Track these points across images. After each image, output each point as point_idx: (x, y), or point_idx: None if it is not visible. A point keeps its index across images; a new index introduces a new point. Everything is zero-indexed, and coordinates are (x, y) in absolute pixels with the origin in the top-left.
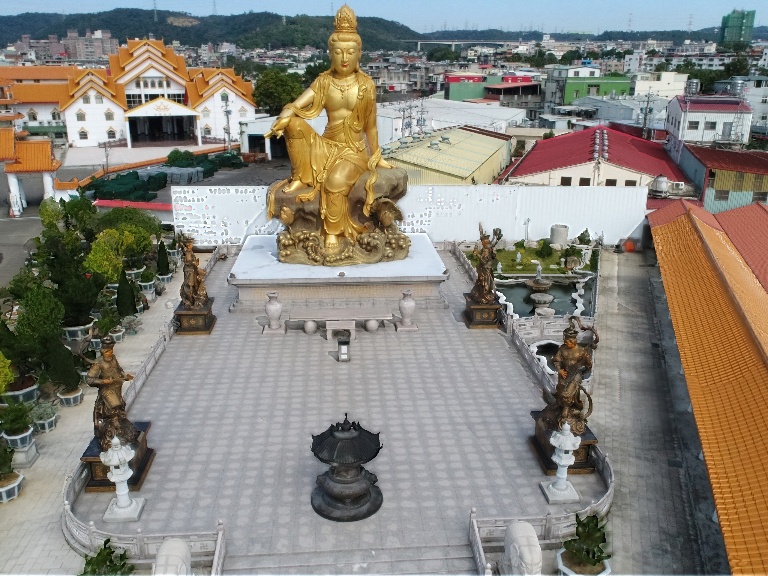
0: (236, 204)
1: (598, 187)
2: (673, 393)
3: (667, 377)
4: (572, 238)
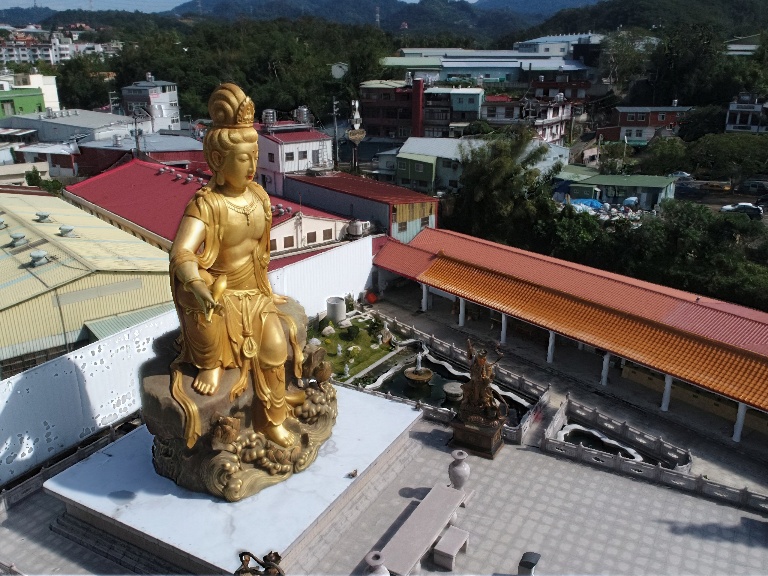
0: None
1: (341, 247)
2: (701, 432)
3: (668, 420)
4: None
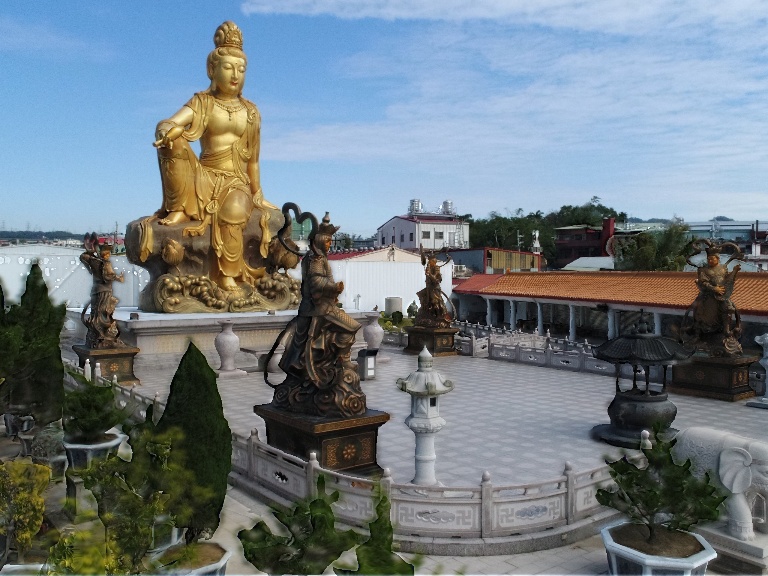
0: (19, 278)
1: (414, 262)
2: None
3: None
4: None
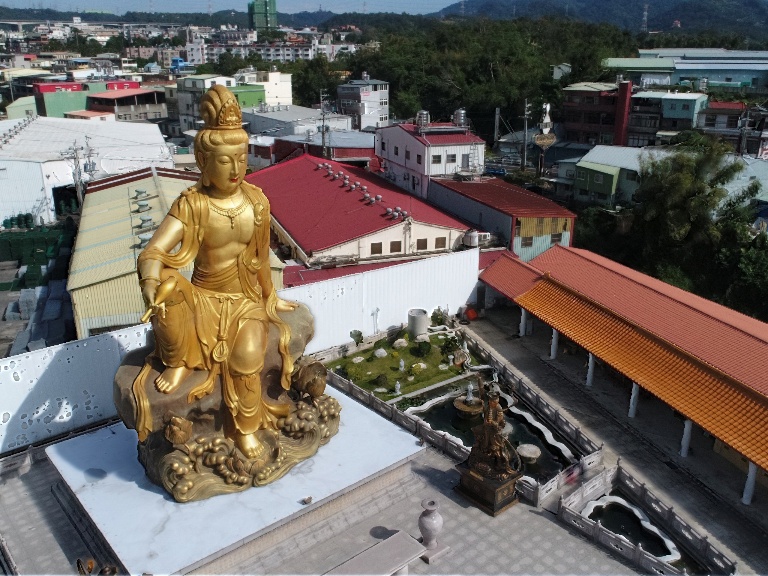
0: None
1: (438, 258)
2: None
3: (743, 515)
4: None
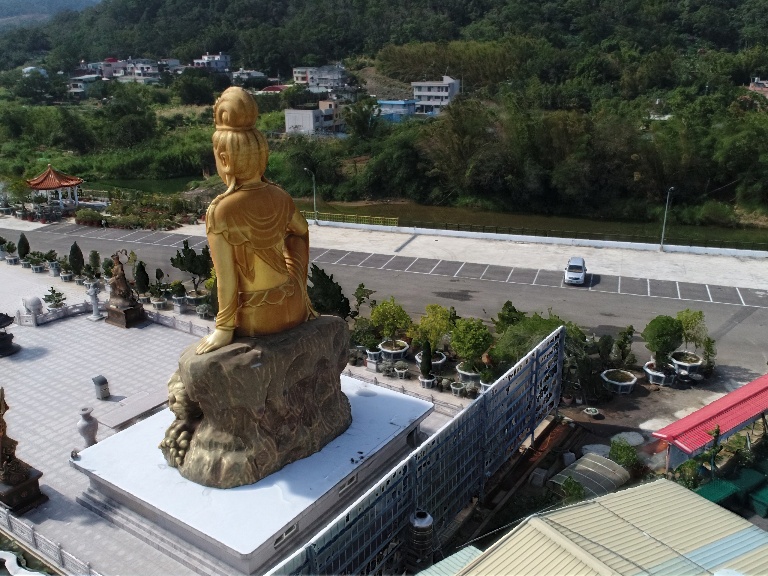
0: None
1: None
2: None
3: None
4: None
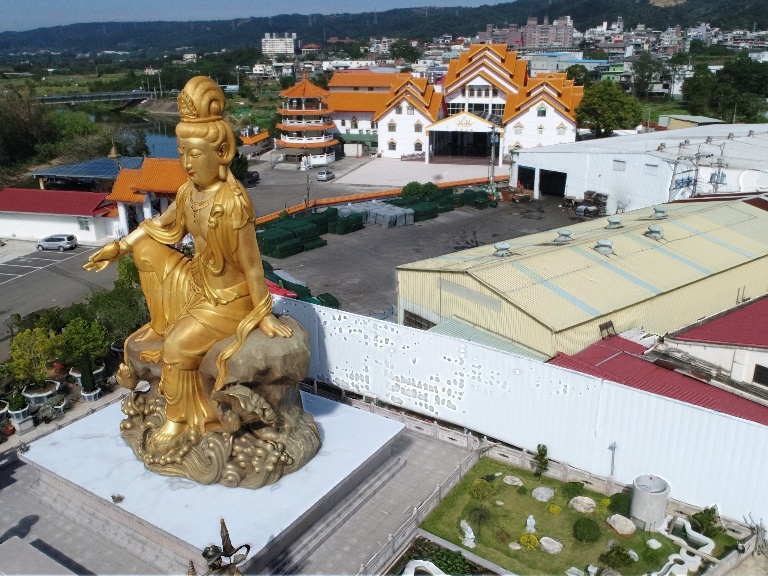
0: None
1: (765, 428)
2: None
3: None
4: (701, 504)
